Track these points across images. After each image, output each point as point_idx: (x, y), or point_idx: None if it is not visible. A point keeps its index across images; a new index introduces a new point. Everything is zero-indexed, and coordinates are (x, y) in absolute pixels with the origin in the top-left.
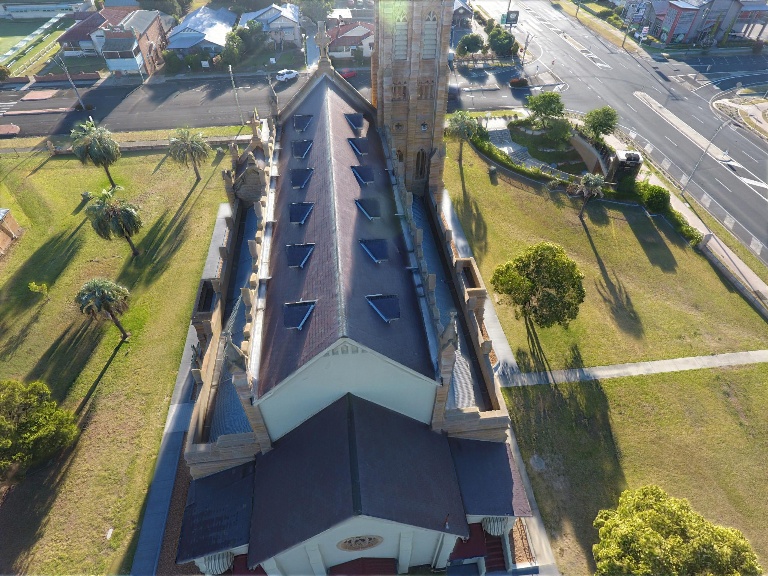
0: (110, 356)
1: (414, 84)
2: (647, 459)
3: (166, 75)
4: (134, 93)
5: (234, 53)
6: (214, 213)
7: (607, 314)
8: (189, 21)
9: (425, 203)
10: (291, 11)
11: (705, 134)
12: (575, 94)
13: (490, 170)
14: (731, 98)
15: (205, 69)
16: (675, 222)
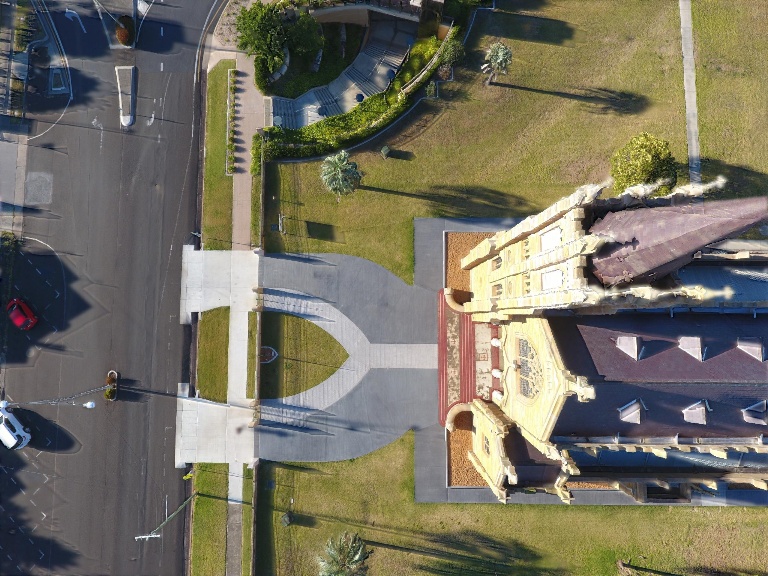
0: (645, 573)
1: None
2: (765, 154)
3: None
4: None
5: None
6: (435, 508)
7: (632, 120)
8: None
9: None
10: None
11: None
12: None
13: (386, 154)
14: None
15: None
16: None
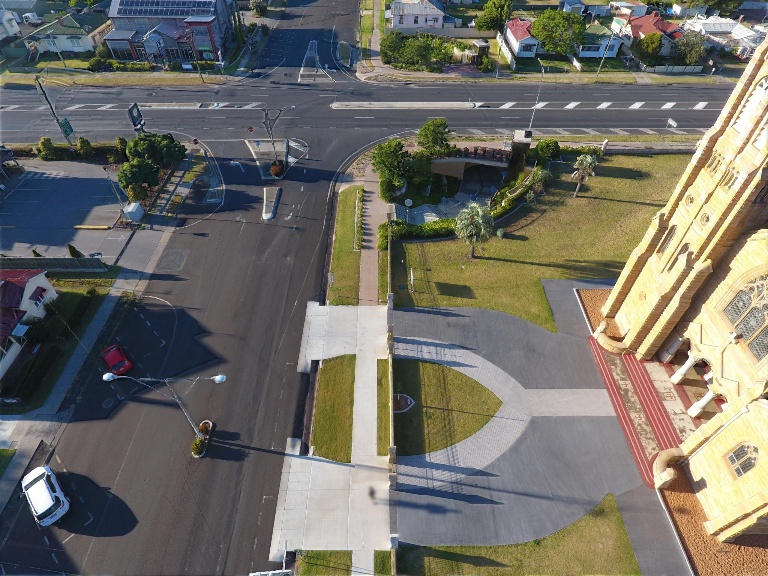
0: None
1: None
2: None
3: None
4: None
5: None
6: None
7: None
8: None
9: None
10: None
11: (427, 100)
12: (319, 140)
13: (502, 235)
14: (356, 71)
15: None
16: (575, 152)
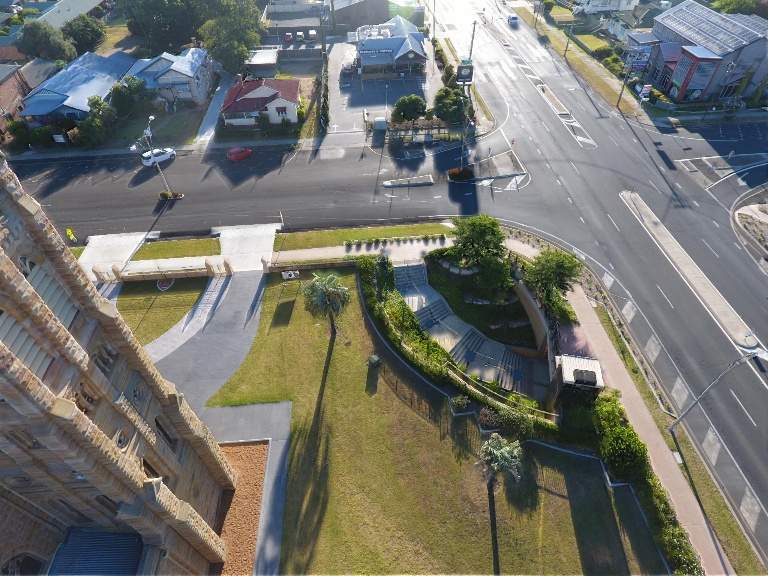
0: None
1: None
2: None
3: (10, 153)
4: None
5: (93, 126)
6: None
7: None
8: (52, 78)
9: None
10: (191, 60)
11: (719, 282)
12: (537, 194)
13: (370, 361)
14: (763, 203)
15: (61, 144)
16: (652, 513)
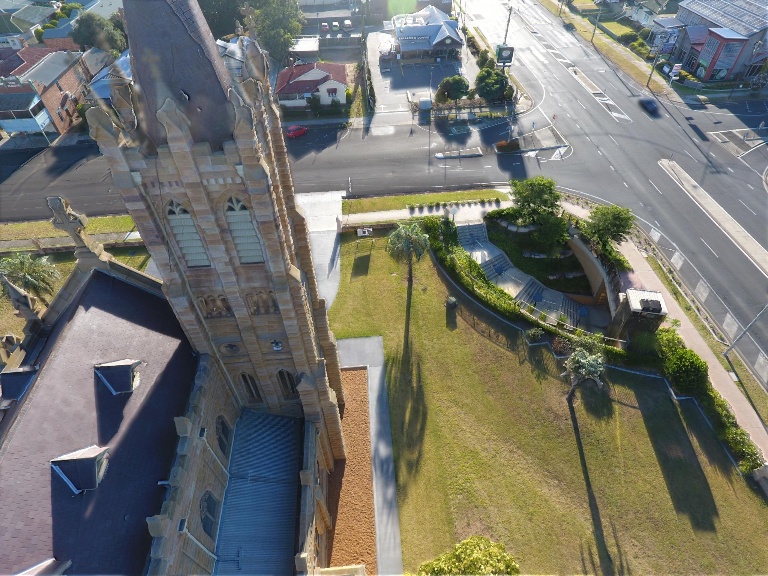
0: None
1: (235, 299)
2: None
3: (80, 133)
4: (32, 161)
5: None
6: None
7: None
8: (115, 64)
9: (303, 433)
10: (241, 47)
11: (758, 235)
12: (580, 163)
13: (447, 302)
14: None
15: None
16: (715, 418)
